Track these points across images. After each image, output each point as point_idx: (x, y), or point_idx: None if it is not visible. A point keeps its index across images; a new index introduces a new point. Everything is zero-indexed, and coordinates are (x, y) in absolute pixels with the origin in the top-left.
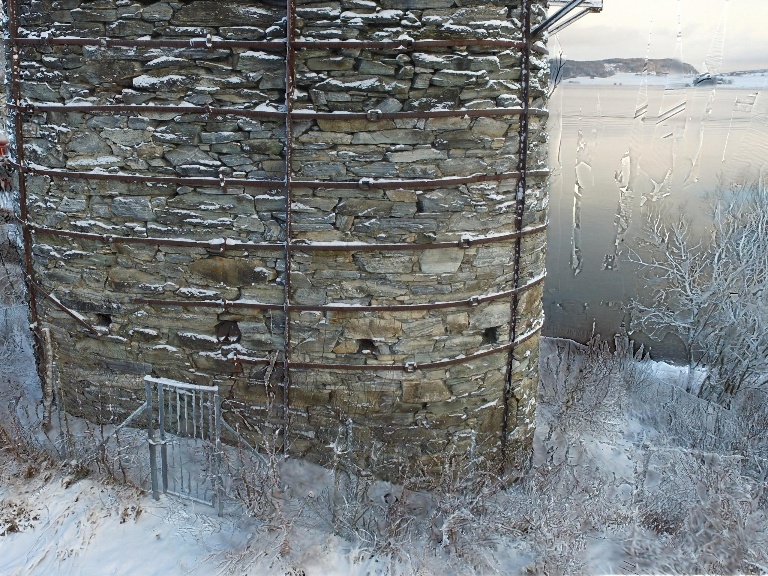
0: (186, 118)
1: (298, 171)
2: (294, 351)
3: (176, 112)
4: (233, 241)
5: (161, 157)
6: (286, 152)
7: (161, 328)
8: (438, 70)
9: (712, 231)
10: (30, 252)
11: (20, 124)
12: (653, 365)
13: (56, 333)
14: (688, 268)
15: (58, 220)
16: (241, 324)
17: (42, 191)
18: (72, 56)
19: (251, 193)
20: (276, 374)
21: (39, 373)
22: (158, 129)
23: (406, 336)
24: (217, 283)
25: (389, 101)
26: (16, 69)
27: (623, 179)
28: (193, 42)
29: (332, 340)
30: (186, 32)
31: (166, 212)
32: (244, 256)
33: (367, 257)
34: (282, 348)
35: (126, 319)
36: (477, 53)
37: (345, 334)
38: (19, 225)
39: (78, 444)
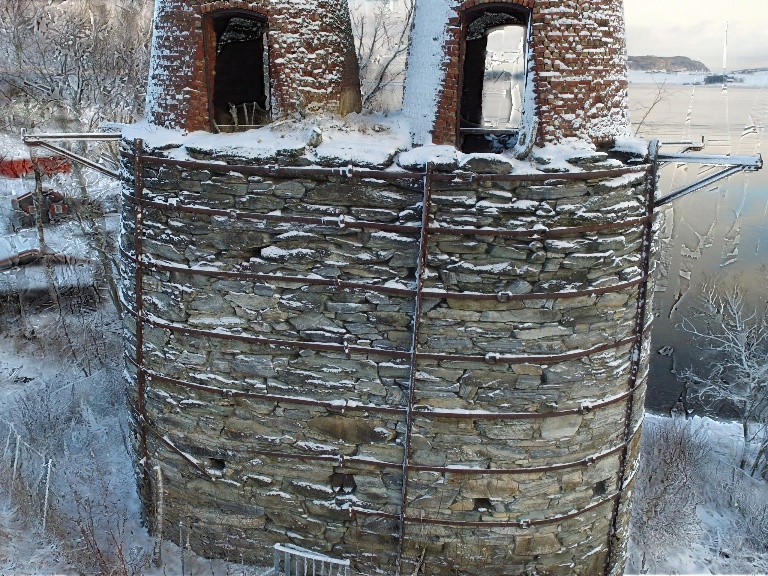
0: (313, 288)
1: (424, 343)
2: (409, 505)
3: (303, 282)
4: (354, 403)
5: (285, 321)
6: (414, 326)
7: (275, 475)
8: (569, 254)
9: (767, 301)
10: (143, 393)
11: (140, 277)
12: (698, 421)
13: (167, 471)
14: (745, 341)
15: (176, 370)
16: (357, 478)
17: (161, 342)
18: (200, 224)
19: (375, 359)
20: (390, 525)
21: (141, 498)
22: (284, 296)
23: (522, 495)
24: (335, 439)
25: (520, 284)
26: (139, 227)
27: (666, 230)
28: (325, 221)
29: (449, 498)
30: (318, 210)
31: (288, 372)
32: (364, 416)
33: (489, 424)
34: (398, 502)
35: (241, 466)
36: (605, 234)
37: (463, 494)
38: (130, 363)
39: None
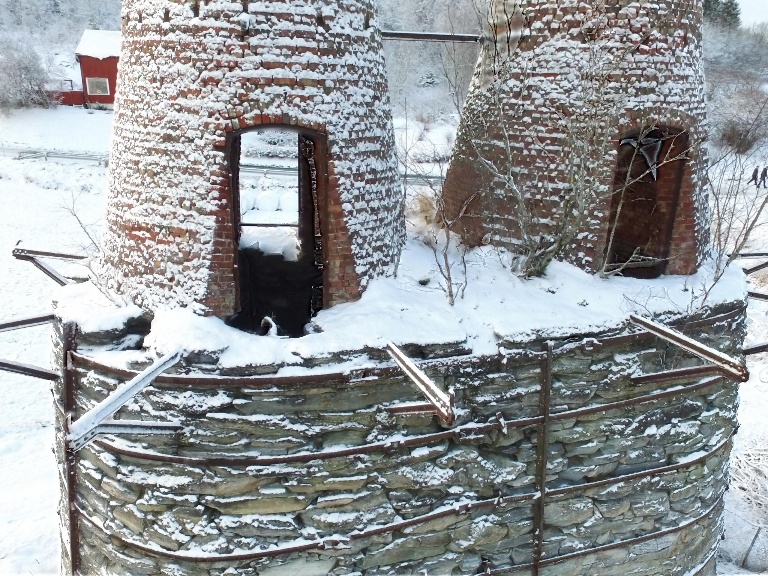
0: None
1: None
2: None
3: None
4: None
5: None
6: None
7: None
8: None
9: None
10: None
11: None
12: None
13: None
14: None
15: None
16: None
17: None
18: None
19: None
20: None
21: None
22: None
23: None
24: None
25: None
26: None
27: None
28: None
29: None
30: None
31: None
32: None
33: None
34: None
35: None
36: None
37: None
38: None
39: None
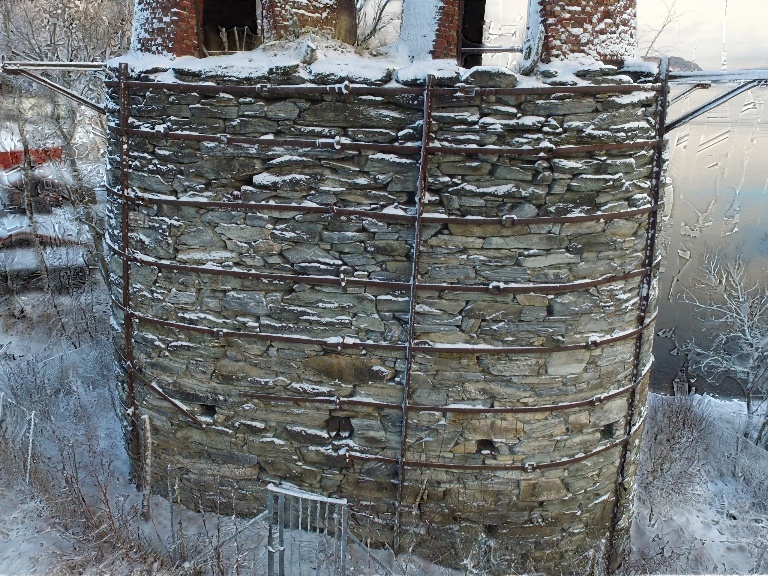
0: (308, 217)
1: (425, 273)
2: (409, 449)
3: (297, 211)
4: (351, 340)
5: (278, 254)
6: (414, 255)
7: (269, 421)
8: (576, 175)
9: None
10: (130, 338)
11: (126, 213)
12: None
13: (155, 420)
14: (748, 312)
15: (165, 311)
16: (354, 421)
17: (149, 281)
18: (189, 151)
19: (372, 293)
20: (389, 471)
21: (129, 453)
22: (277, 227)
23: (527, 436)
24: (332, 380)
25: (525, 207)
26: (125, 159)
27: (665, 208)
28: (320, 143)
29: (451, 440)
30: (312, 132)
31: (281, 309)
32: (362, 354)
33: (492, 360)
34: (397, 446)
35: (232, 411)
36: (614, 155)
37: (465, 435)
38: (116, 308)
39: (190, 546)
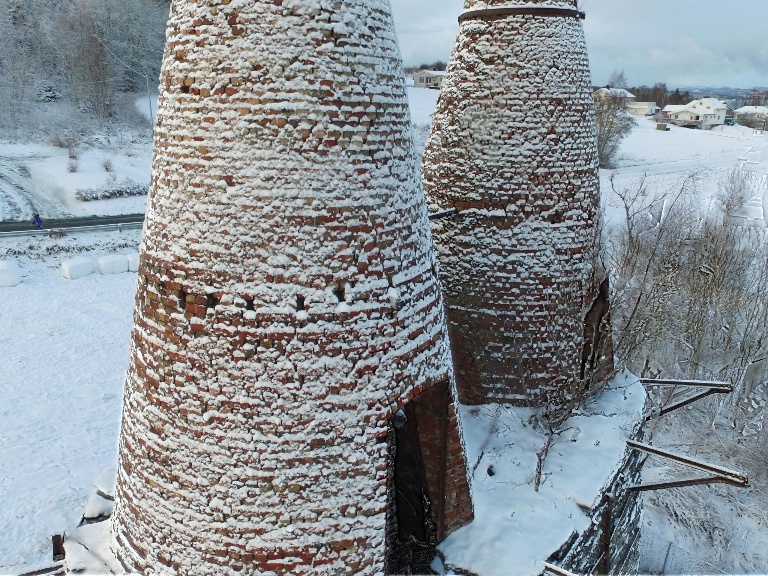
0: None
1: None
2: None
3: None
4: None
5: None
6: None
7: None
8: None
9: None
10: None
11: None
12: None
13: (392, 539)
14: None
15: None
16: None
17: None
18: None
19: None
20: None
21: None
22: None
23: None
24: None
25: None
26: None
27: None
28: None
29: None
30: None
31: None
32: None
33: None
34: None
35: None
36: None
37: None
38: None
39: None
